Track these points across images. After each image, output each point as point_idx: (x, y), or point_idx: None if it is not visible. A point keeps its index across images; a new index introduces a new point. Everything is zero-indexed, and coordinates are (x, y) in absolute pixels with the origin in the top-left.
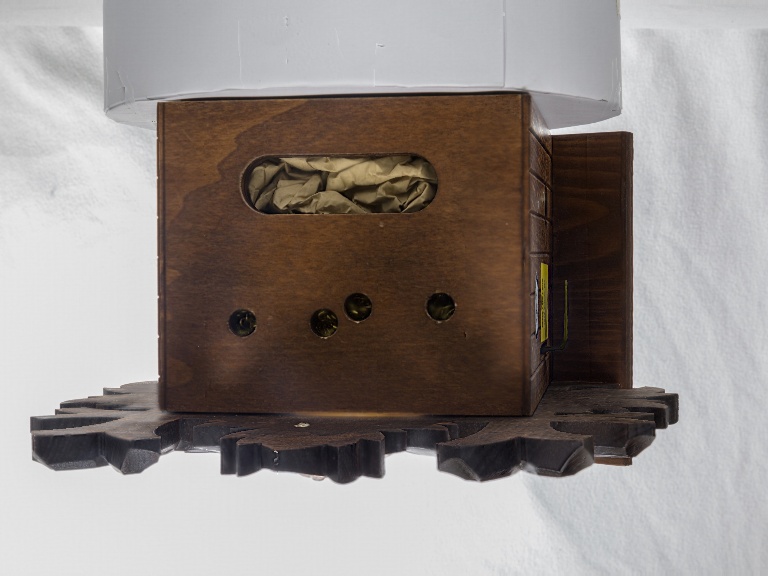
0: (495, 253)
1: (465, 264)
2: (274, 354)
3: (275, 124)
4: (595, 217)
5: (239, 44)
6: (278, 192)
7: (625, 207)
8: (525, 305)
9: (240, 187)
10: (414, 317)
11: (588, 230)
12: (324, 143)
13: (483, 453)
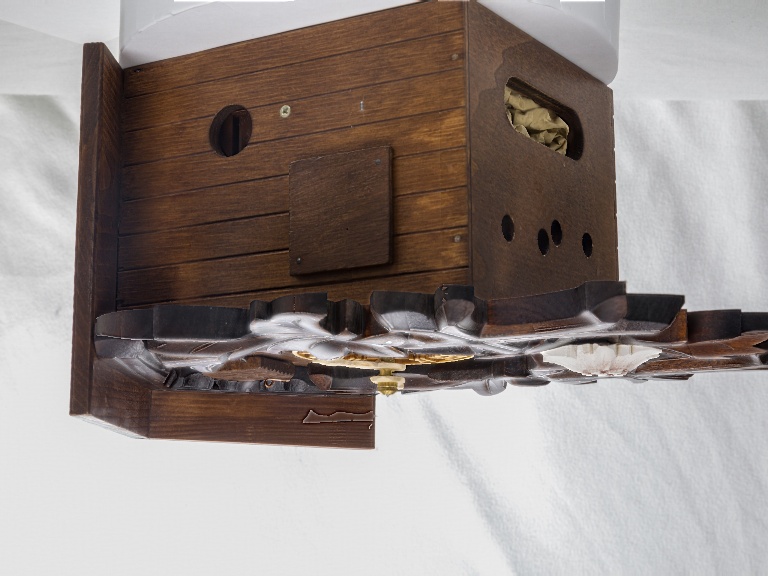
0: (605, 208)
1: (595, 213)
2: (523, 263)
3: (519, 51)
4: None
5: None
6: None
7: None
8: None
9: None
10: None
11: None
12: (540, 81)
13: None
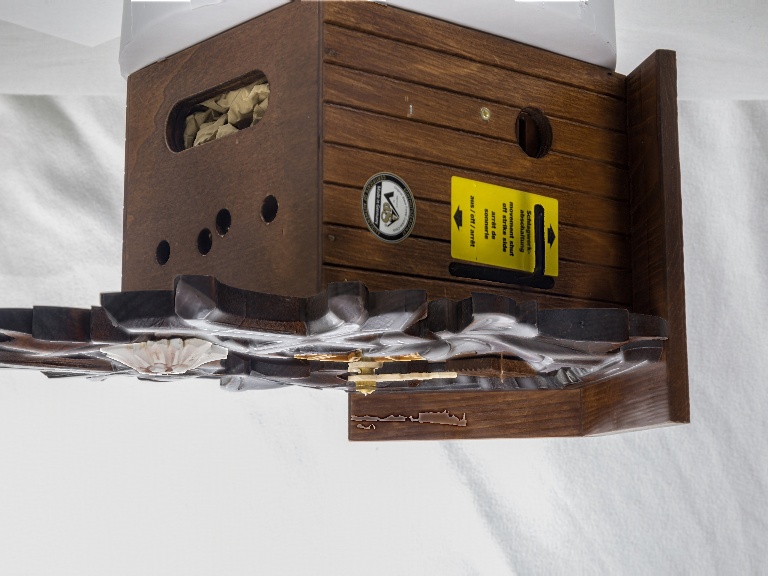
0: (301, 147)
1: (284, 164)
2: None
3: (183, 72)
4: (646, 150)
5: (129, 3)
6: (197, 134)
7: (660, 131)
8: (319, 193)
9: (165, 133)
10: (254, 223)
11: (644, 166)
12: (208, 79)
13: (124, 299)
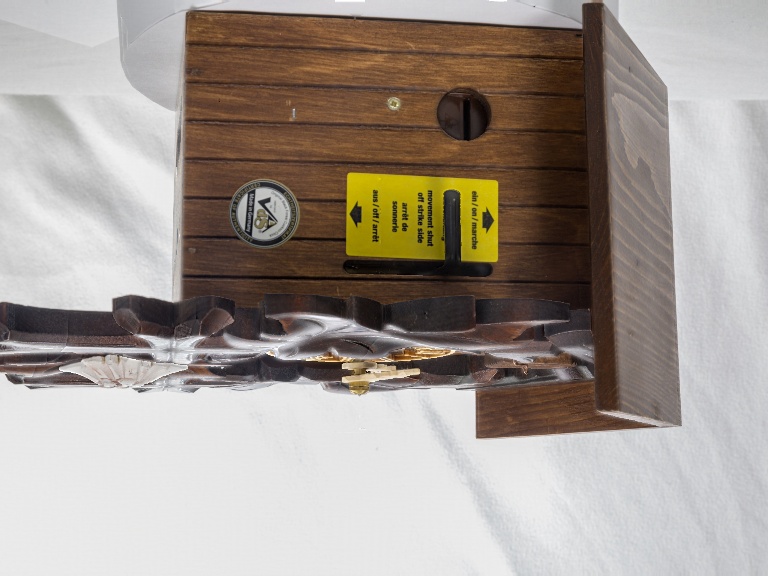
0: None
1: None
2: None
3: None
4: None
5: None
6: None
7: (585, 93)
8: None
9: (176, 161)
10: None
11: None
12: None
13: None
